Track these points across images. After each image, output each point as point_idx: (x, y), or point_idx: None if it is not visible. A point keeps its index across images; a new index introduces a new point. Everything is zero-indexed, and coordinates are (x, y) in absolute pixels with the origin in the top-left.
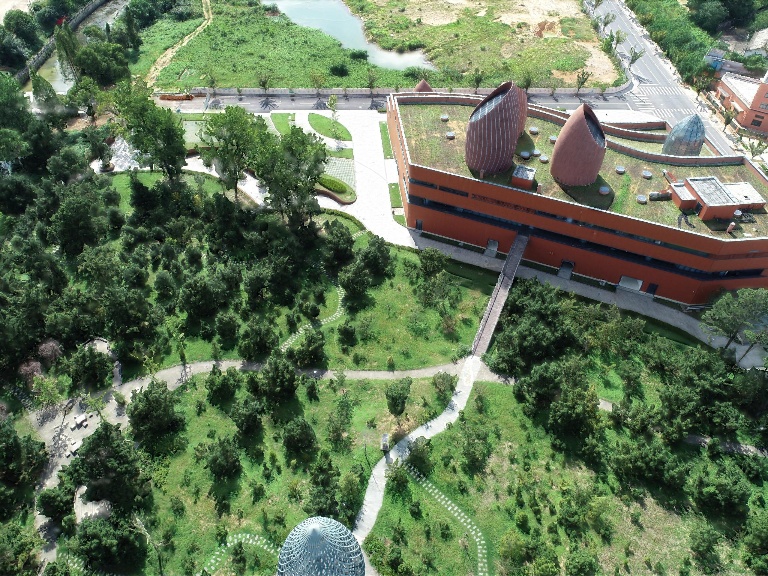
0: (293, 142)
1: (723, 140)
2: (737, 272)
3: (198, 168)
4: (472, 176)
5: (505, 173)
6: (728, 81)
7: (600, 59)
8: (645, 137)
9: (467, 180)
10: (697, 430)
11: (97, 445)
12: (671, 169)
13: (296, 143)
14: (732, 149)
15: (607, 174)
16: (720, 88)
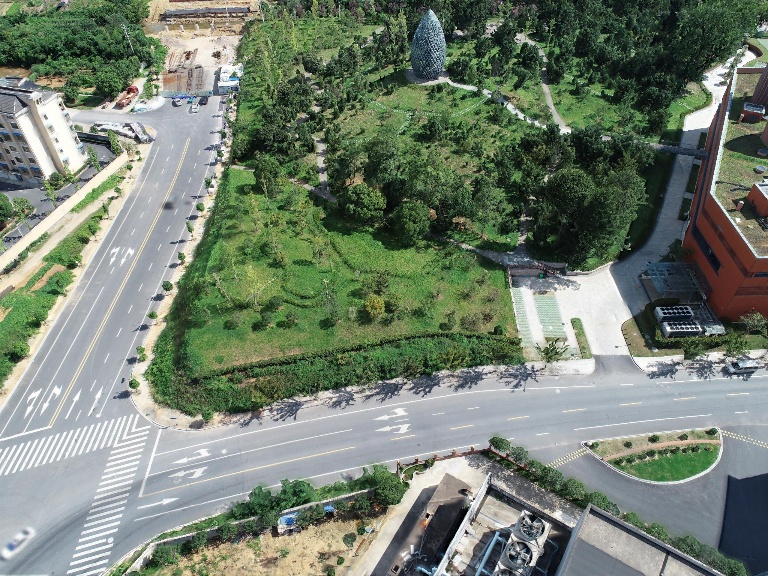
0: (713, 13)
1: None
2: None
3: None
4: None
5: None
6: None
7: None
8: None
9: None
10: None
11: (474, 2)
12: None
13: (713, 14)
14: None
15: None
16: None
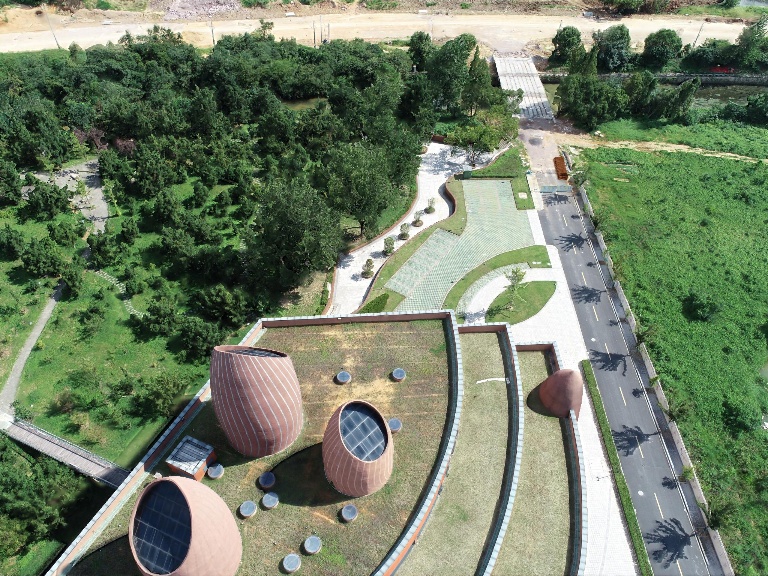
0: None
1: None
2: None
3: (422, 204)
4: None
5: (225, 442)
6: None
7: None
8: None
9: None
10: None
11: None
12: None
13: None
14: None
15: None
16: None
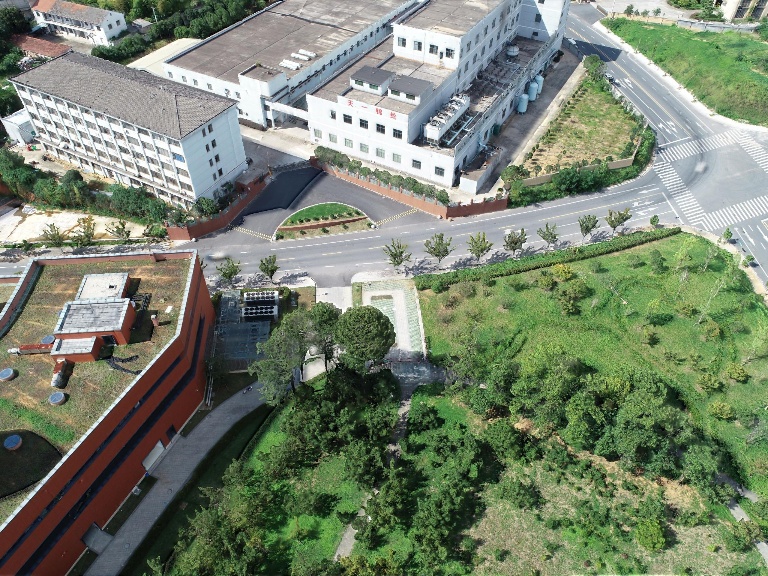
0: None
1: None
2: None
3: None
4: None
5: None
6: None
7: None
8: None
9: None
10: None
11: None
12: (9, 342)
13: None
14: None
15: None
16: None
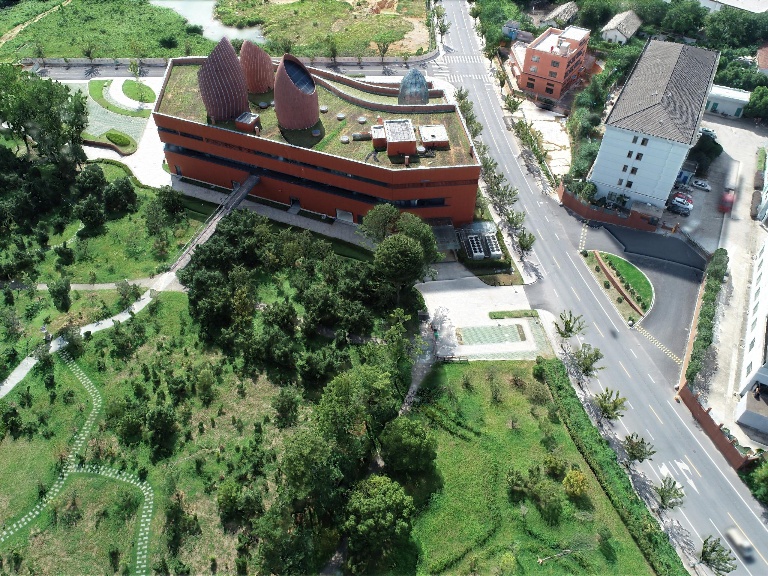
0: (41, 92)
1: (497, 101)
2: (425, 202)
3: (5, 127)
4: (206, 122)
5: None
6: (514, 49)
7: (420, 32)
8: (392, 92)
9: (197, 125)
10: (339, 327)
11: None
12: (388, 116)
13: (44, 93)
14: (501, 108)
15: (328, 120)
16: (510, 56)
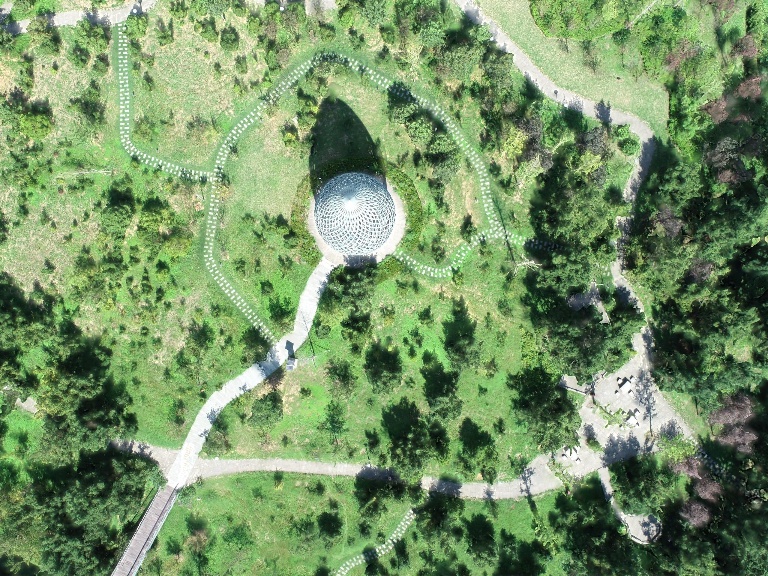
0: None
1: None
2: None
3: None
4: None
5: None
6: None
7: None
8: None
9: None
10: None
11: (594, 348)
12: None
13: None
14: None
15: None
16: None
